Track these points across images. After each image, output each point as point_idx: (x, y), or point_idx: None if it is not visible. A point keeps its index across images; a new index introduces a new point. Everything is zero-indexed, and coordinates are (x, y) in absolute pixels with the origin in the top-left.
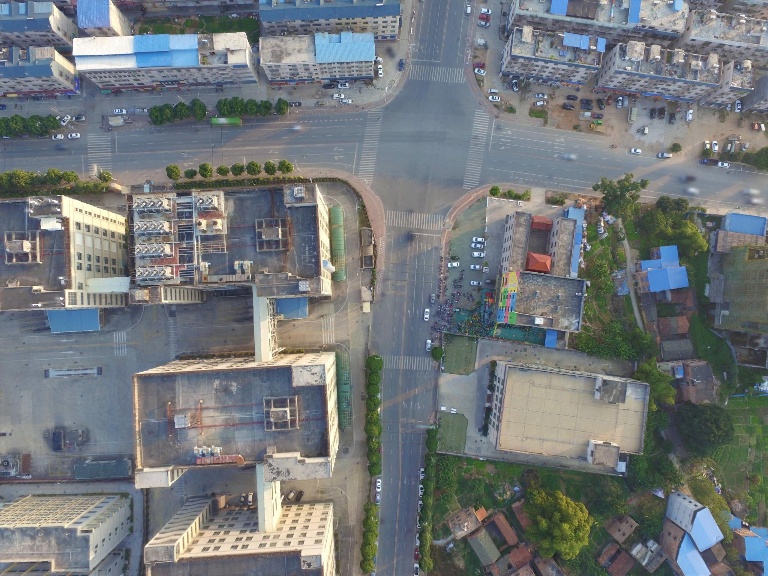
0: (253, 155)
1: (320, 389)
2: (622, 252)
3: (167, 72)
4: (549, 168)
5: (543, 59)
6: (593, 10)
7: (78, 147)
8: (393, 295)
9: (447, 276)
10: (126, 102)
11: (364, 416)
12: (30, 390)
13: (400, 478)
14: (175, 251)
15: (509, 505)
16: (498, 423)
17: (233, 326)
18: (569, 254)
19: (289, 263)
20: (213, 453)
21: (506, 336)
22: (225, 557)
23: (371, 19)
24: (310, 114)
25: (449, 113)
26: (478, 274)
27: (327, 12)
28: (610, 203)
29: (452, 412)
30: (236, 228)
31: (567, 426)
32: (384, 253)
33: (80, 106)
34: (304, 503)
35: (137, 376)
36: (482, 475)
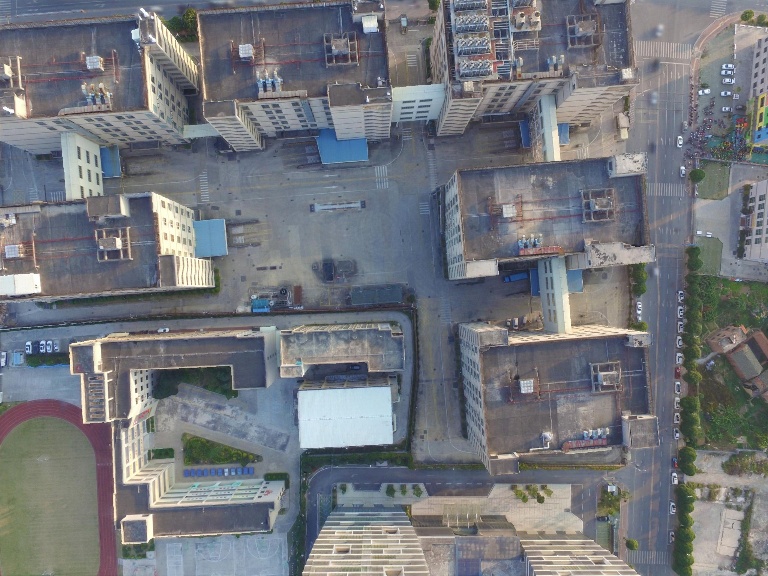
0: None
1: (633, 182)
2: None
3: None
4: None
5: None
6: None
7: None
8: (645, 124)
9: (698, 103)
10: None
11: None
12: (297, 225)
13: (659, 301)
14: (492, 47)
15: (764, 324)
16: None
17: (491, 158)
18: None
19: None
20: (535, 244)
21: (757, 161)
22: None
23: None
24: None
25: None
26: (728, 101)
27: None
28: None
29: (708, 236)
30: (546, 26)
31: None
32: None
33: None
34: None
35: None
36: (738, 296)
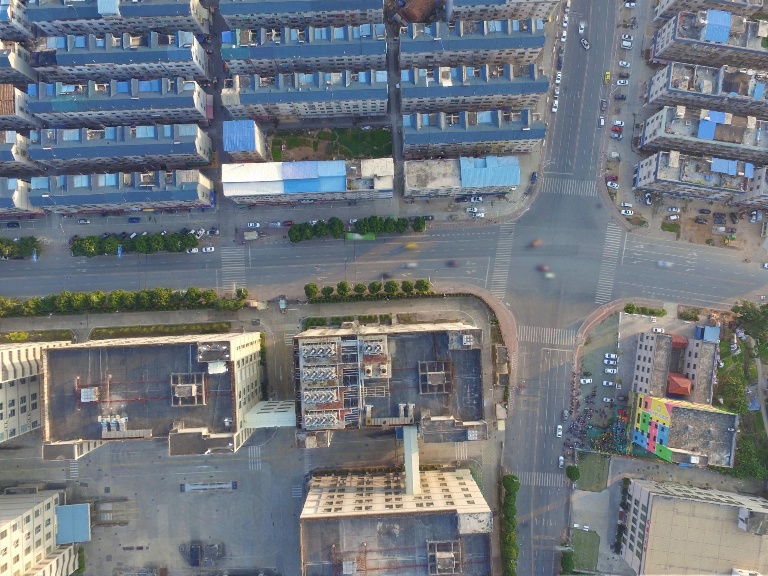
0: (386, 269)
1: None
2: (754, 368)
3: (311, 195)
4: (681, 283)
5: (688, 183)
6: (740, 134)
7: (212, 260)
8: (525, 411)
9: (579, 392)
10: (259, 215)
11: (496, 532)
12: (166, 504)
13: None
14: (340, 395)
15: None
16: (641, 551)
17: (366, 441)
18: (709, 378)
19: (451, 405)
20: None
21: (638, 453)
22: None
23: (514, 141)
24: (443, 228)
25: (581, 226)
26: (610, 390)
27: (472, 136)
28: (749, 324)
29: (585, 529)
30: (398, 370)
31: (710, 554)
32: (516, 368)
33: (213, 219)
34: None
35: None
36: None
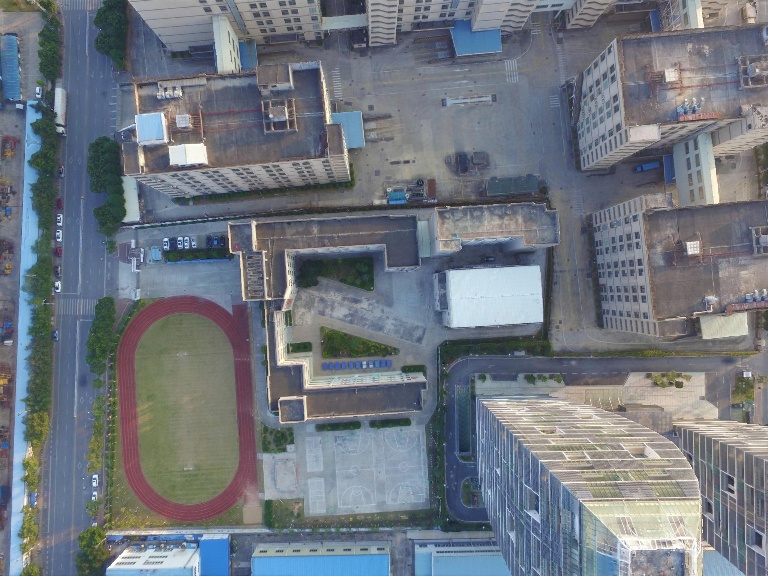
0: None
1: None
2: None
3: None
4: None
5: None
6: None
7: None
8: None
9: None
10: None
11: None
12: (429, 119)
13: None
14: None
15: None
16: None
17: None
18: None
19: None
20: (694, 111)
21: None
22: (718, 203)
23: None
24: None
25: None
26: None
27: None
28: None
29: None
30: None
31: None
32: None
33: None
34: None
35: None
36: None
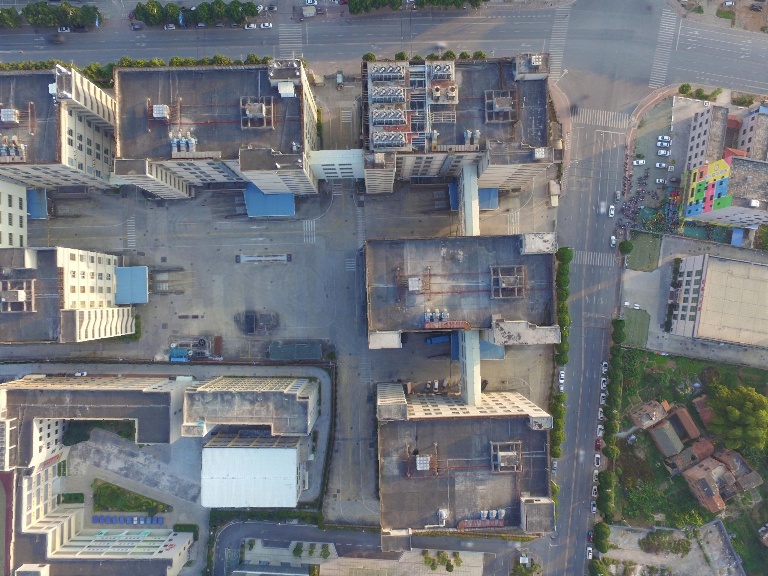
0: (442, 49)
1: (545, 260)
2: None
3: None
4: (735, 69)
5: None
6: None
7: (269, 37)
8: (578, 191)
9: (632, 174)
10: None
11: None
12: (222, 275)
13: (582, 371)
14: (408, 119)
15: (689, 401)
16: (695, 312)
17: (420, 217)
18: (765, 149)
19: (515, 136)
20: (441, 318)
21: (689, 235)
22: None
23: None
24: (499, 9)
25: (636, 12)
26: (663, 173)
27: None
28: None
29: (635, 308)
30: (464, 100)
31: (764, 316)
32: (570, 150)
33: None
34: (489, 391)
35: (367, 242)
36: (663, 370)
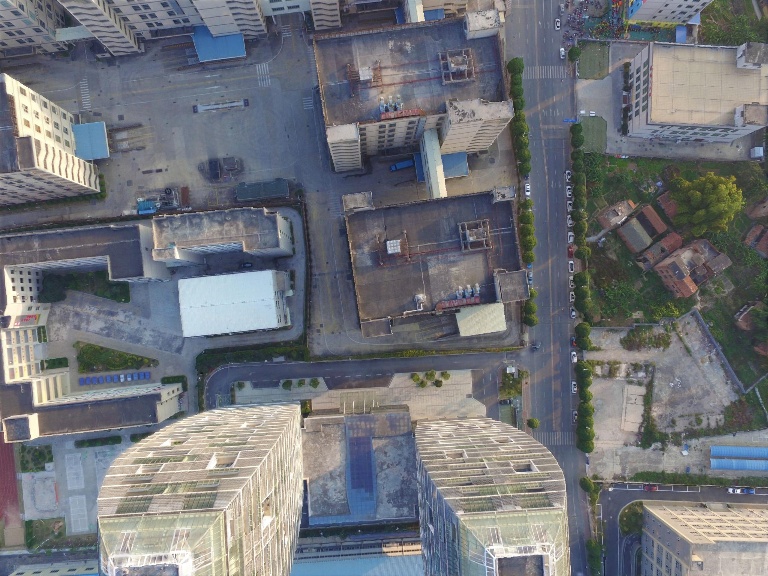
0: None
1: (491, 42)
2: None
3: None
4: None
5: None
6: None
7: None
8: (523, 9)
9: None
10: None
11: (506, 126)
12: (181, 126)
13: (547, 182)
14: None
15: (653, 199)
16: (647, 99)
17: None
18: None
19: None
20: (396, 108)
21: (636, 39)
22: None
23: None
24: None
25: None
26: None
27: None
28: None
29: (591, 115)
30: None
31: (713, 96)
32: None
33: None
34: None
35: None
36: None
